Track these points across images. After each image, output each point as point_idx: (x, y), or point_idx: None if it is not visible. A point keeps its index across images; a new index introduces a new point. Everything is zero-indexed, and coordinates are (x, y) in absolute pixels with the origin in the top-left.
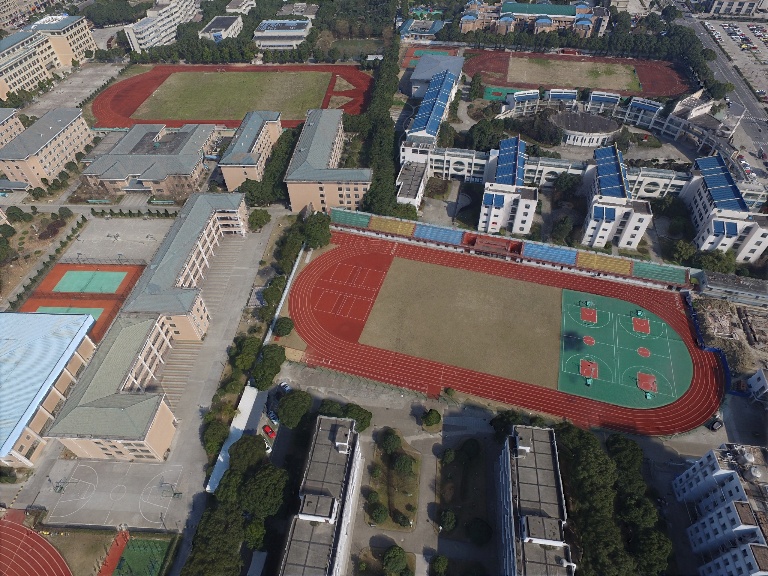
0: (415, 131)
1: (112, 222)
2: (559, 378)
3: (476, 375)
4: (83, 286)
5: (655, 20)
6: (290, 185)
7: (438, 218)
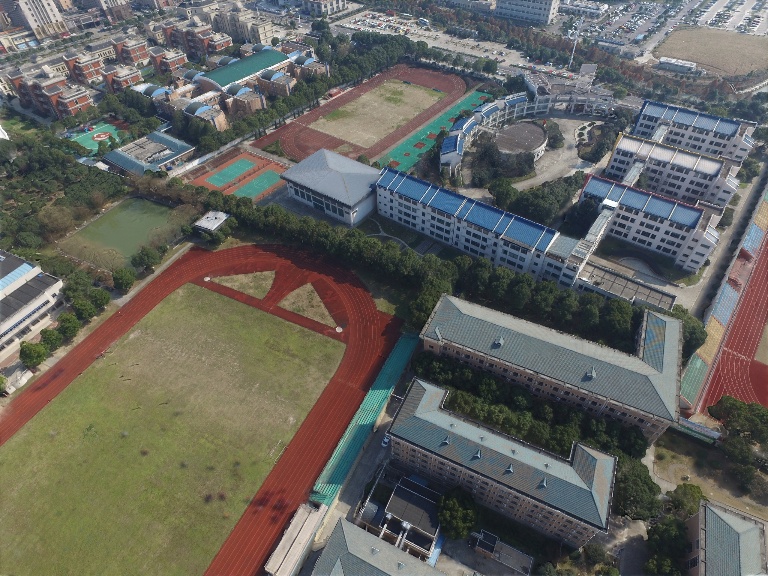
0: (546, 243)
1: None
2: None
3: None
4: None
5: (340, 35)
6: None
7: None
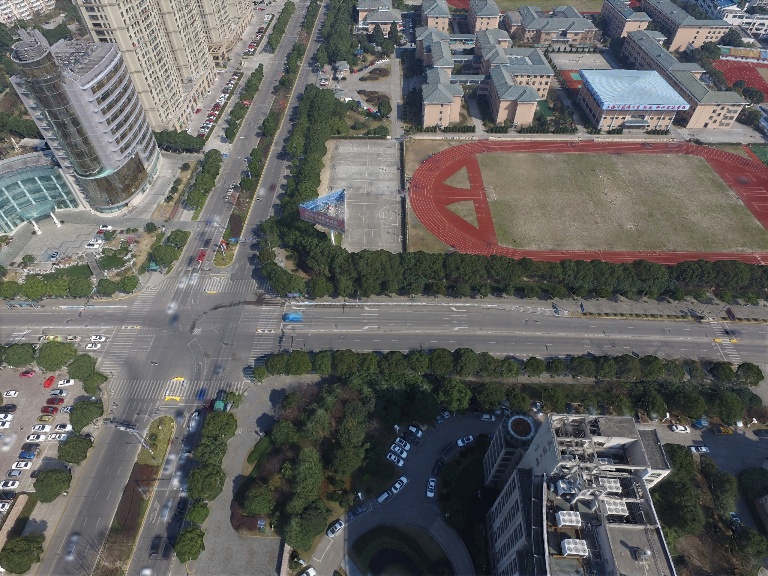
0: (727, 6)
1: (562, 55)
2: None
3: None
4: None
5: None
6: (680, 29)
7: None
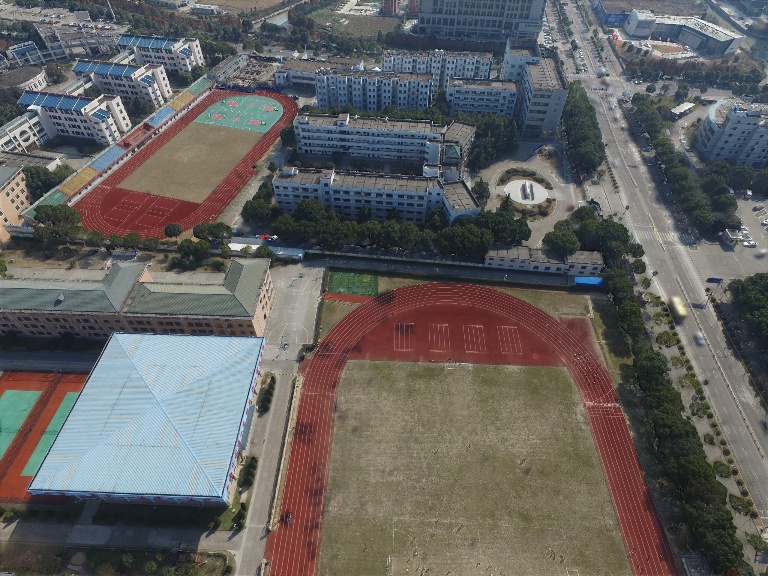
0: None
1: None
2: (258, 132)
3: (247, 157)
4: (5, 434)
5: None
6: None
7: (80, 164)
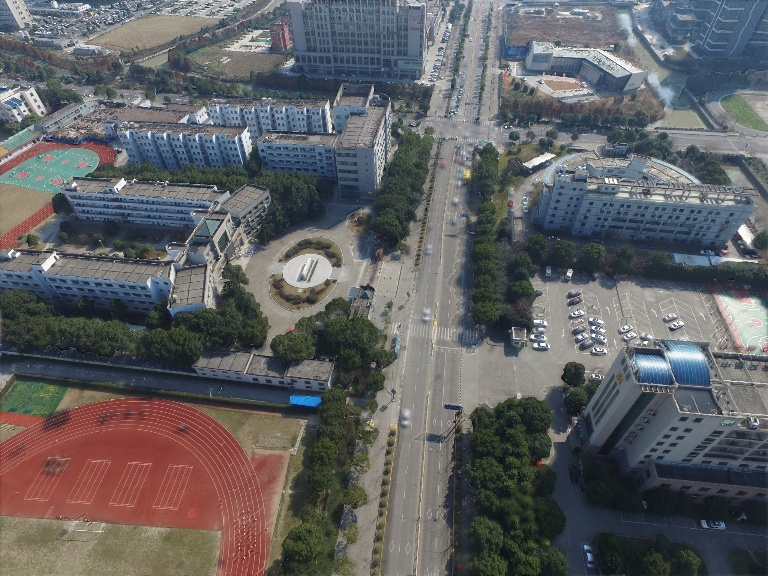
0: None
1: None
2: (53, 193)
3: (21, 225)
4: None
5: None
6: None
7: None
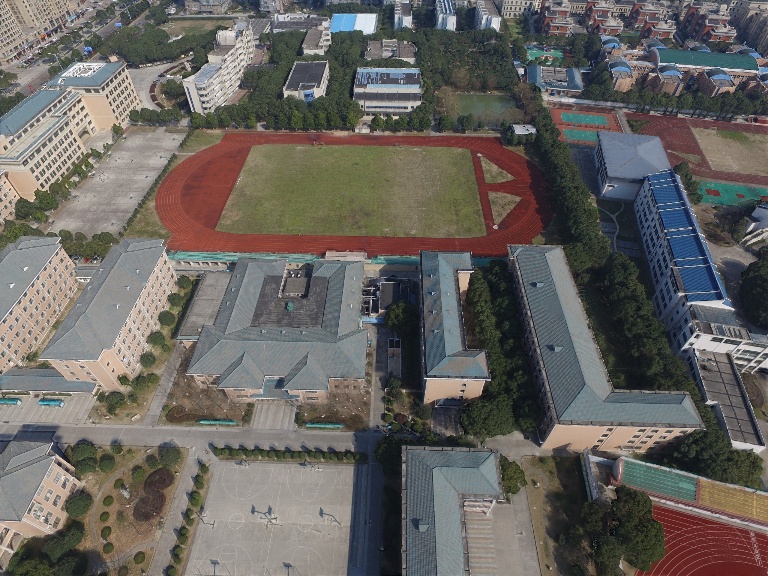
0: (701, 298)
1: (251, 472)
2: None
3: None
4: None
5: None
6: (560, 425)
7: None
